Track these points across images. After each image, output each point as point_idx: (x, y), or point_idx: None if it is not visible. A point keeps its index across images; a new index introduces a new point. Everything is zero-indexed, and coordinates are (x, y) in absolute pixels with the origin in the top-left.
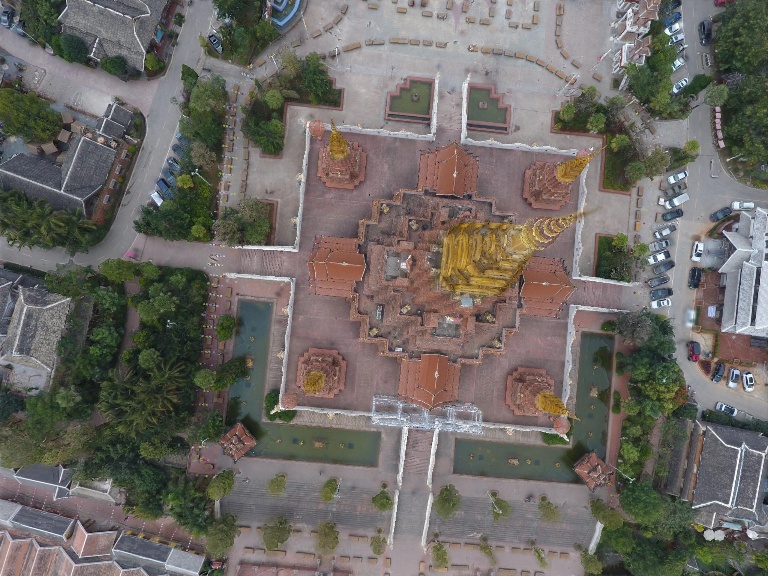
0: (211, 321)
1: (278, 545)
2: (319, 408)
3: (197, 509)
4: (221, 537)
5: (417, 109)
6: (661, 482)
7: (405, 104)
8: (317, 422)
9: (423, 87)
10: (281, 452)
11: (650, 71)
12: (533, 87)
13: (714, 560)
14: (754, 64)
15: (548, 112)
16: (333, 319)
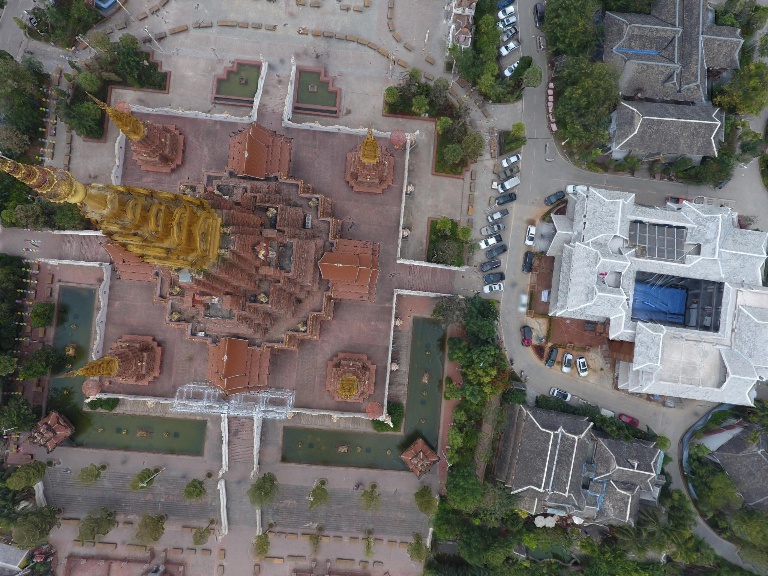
0: (31, 308)
1: (107, 537)
2: (133, 395)
3: (3, 500)
4: (28, 528)
5: (245, 92)
6: (494, 469)
7: (233, 87)
8: (141, 411)
9: (251, 70)
10: (104, 442)
11: (475, 53)
12: (365, 70)
13: (540, 547)
14: (573, 45)
15: (380, 95)
16: (150, 305)
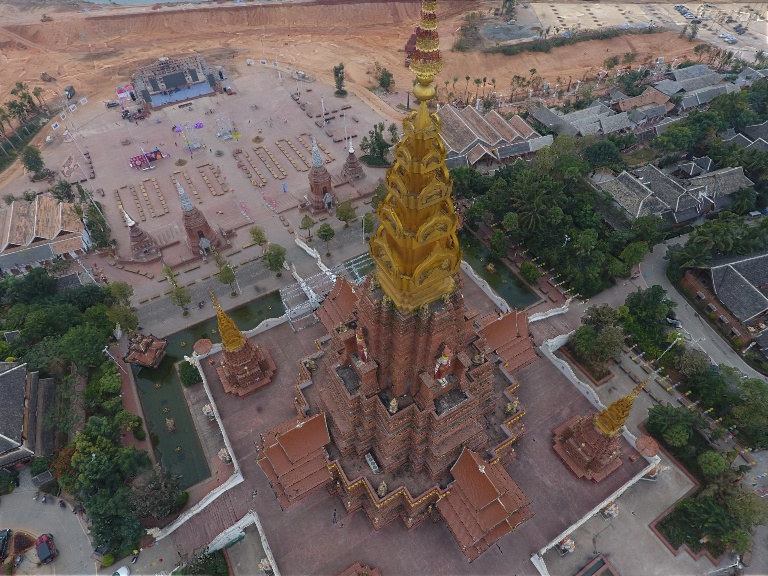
0: None
1: None
2: None
3: None
4: None
5: None
6: None
7: None
8: None
9: None
10: None
11: None
12: None
13: None
14: None
15: None
16: None
